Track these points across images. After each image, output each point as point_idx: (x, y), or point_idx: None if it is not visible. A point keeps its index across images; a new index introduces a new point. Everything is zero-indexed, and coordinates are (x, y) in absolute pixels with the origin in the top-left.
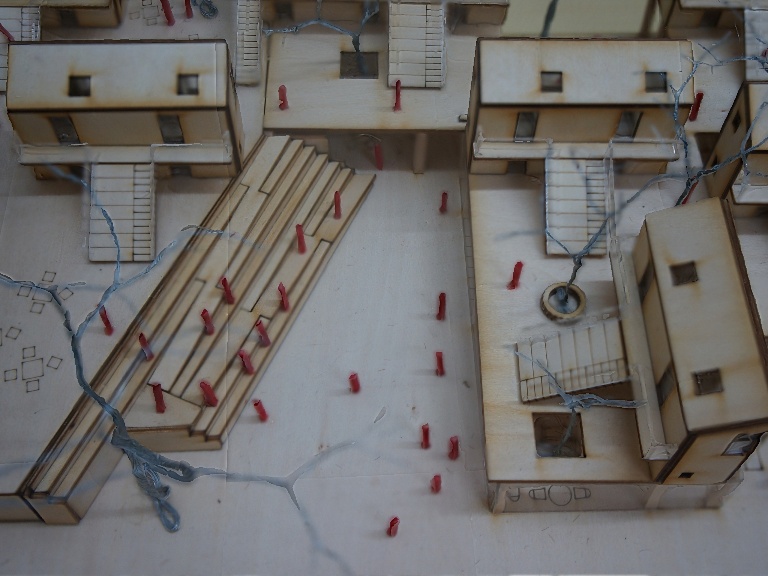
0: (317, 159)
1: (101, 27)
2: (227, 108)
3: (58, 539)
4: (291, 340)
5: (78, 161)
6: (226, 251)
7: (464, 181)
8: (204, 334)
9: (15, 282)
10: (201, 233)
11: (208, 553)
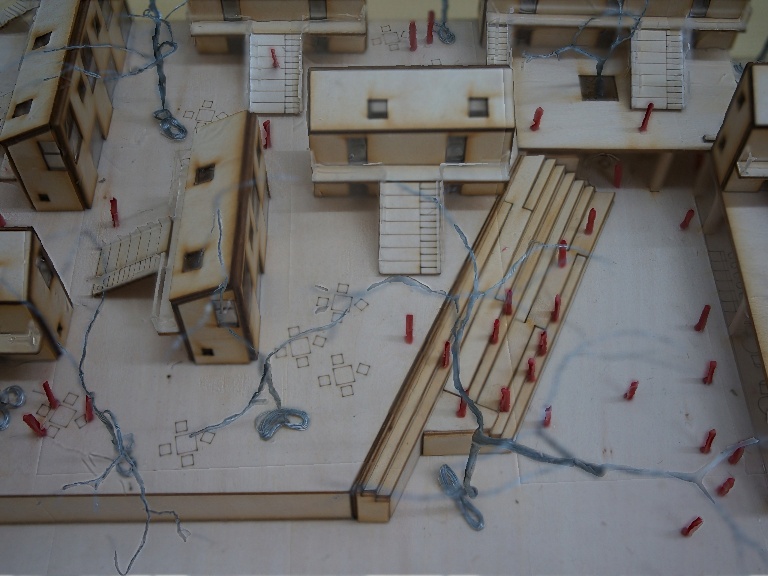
0: (566, 177)
1: (348, 52)
2: (514, 130)
3: (371, 536)
4: (559, 350)
5: (367, 179)
6: (500, 265)
7: (699, 198)
8: (489, 343)
9: (432, 291)
10: (478, 248)
11: (515, 550)
